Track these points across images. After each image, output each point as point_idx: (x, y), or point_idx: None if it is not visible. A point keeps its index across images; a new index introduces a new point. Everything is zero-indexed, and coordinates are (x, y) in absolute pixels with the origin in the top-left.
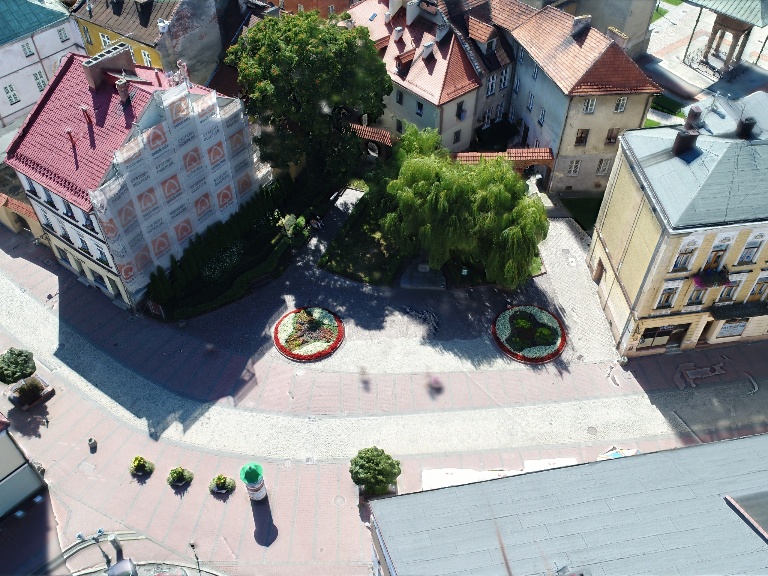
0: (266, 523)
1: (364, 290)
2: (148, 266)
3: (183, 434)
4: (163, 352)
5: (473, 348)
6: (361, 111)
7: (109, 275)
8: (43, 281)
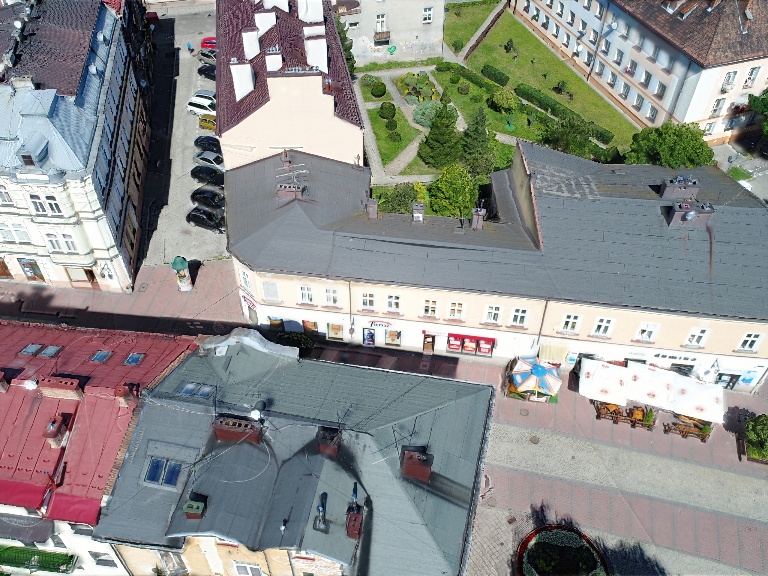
0: None
1: None
2: None
3: None
4: None
5: (640, 573)
6: None
7: None
8: None
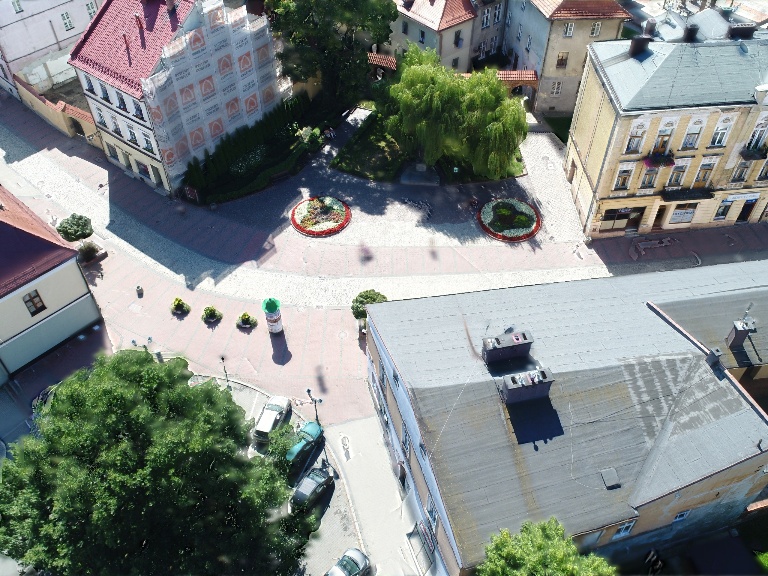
0: (282, 349)
1: (369, 185)
2: (186, 155)
3: (214, 286)
4: (197, 228)
5: (460, 230)
6: (371, 41)
7: (153, 163)
8: (95, 174)
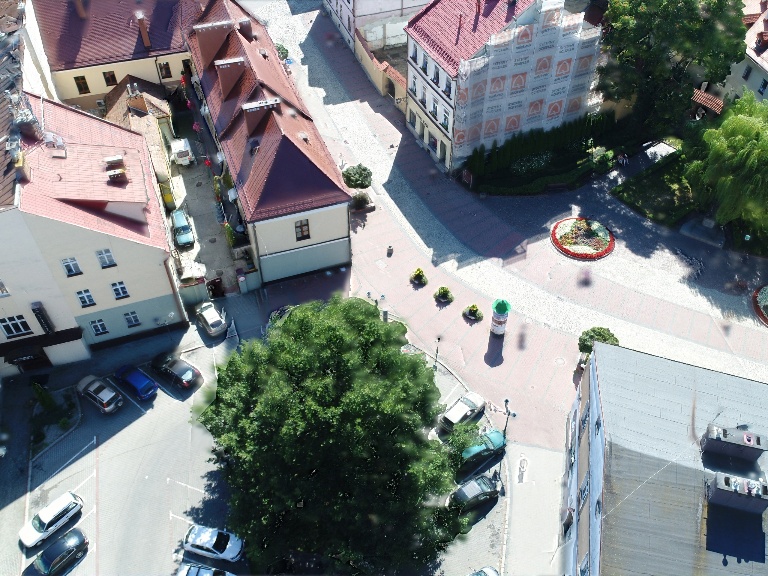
0: (496, 352)
1: (644, 224)
2: (476, 141)
3: (456, 270)
4: (461, 211)
5: (728, 301)
6: (703, 78)
7: (443, 139)
8: (391, 134)
